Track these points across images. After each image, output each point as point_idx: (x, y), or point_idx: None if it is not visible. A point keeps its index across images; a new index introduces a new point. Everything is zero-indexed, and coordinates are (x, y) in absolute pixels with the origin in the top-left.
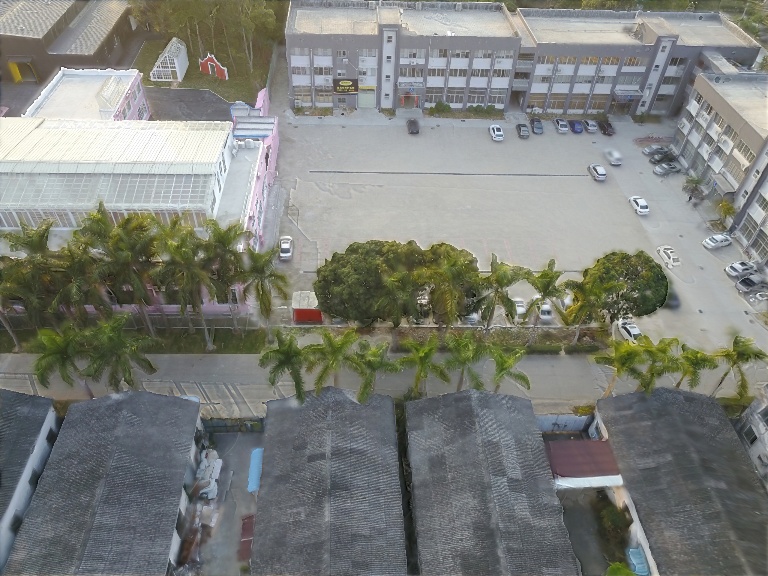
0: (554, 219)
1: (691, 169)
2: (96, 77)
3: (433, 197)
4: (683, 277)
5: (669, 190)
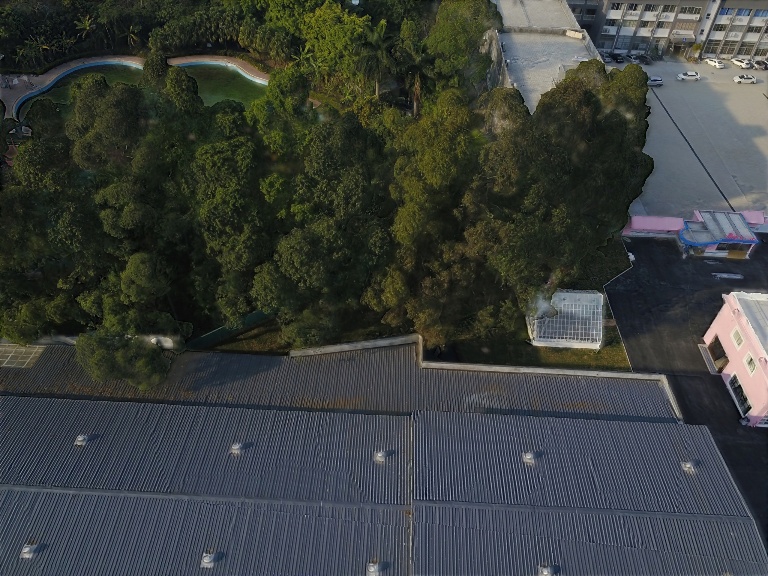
0: (727, 109)
1: (633, 50)
2: (766, 342)
3: (734, 153)
4: (760, 81)
5: (656, 65)
